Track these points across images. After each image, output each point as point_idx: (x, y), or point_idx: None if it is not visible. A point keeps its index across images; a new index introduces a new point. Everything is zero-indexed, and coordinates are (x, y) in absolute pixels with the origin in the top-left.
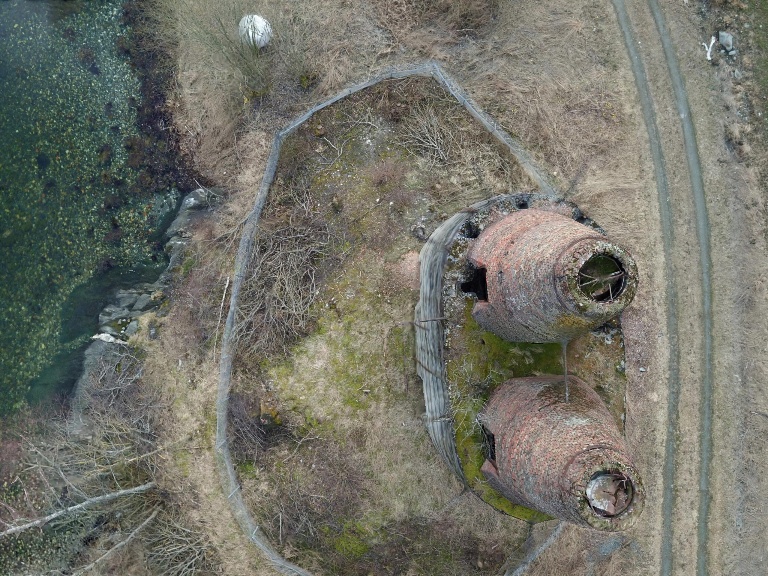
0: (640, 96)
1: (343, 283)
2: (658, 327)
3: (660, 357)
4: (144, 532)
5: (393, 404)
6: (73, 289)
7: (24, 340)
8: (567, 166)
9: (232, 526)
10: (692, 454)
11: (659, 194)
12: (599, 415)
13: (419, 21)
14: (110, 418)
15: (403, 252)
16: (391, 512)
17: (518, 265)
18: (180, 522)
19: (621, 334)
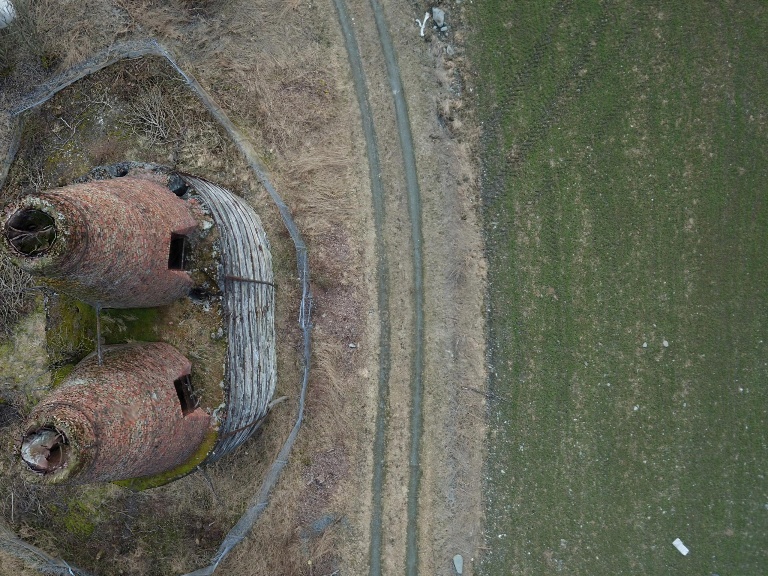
0: (353, 73)
1: None
2: (369, 303)
3: (371, 333)
4: None
5: None
6: None
7: None
8: (283, 143)
9: None
10: (402, 430)
11: (371, 170)
12: (122, 376)
13: (154, 0)
14: None
15: None
16: (107, 490)
17: None
18: None
19: (219, 301)
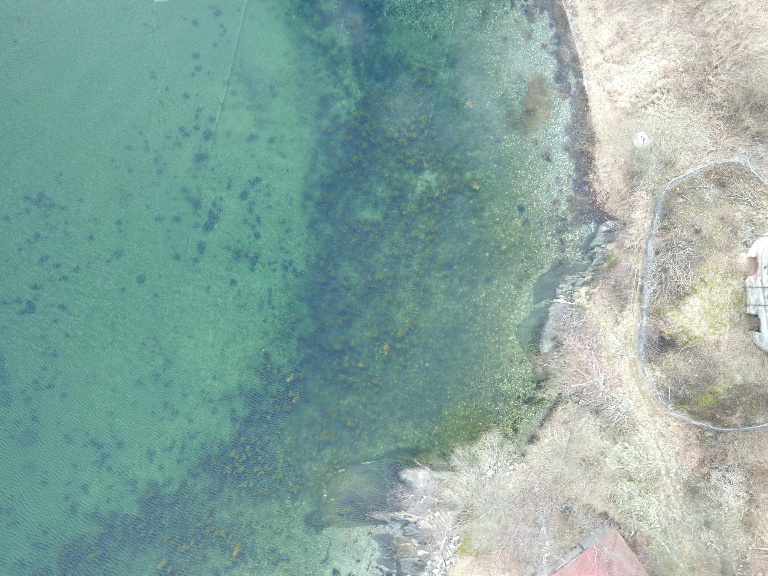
0: None
1: (707, 269)
2: None
3: None
4: None
5: (733, 328)
6: (539, 276)
7: (513, 304)
8: None
9: (640, 395)
10: None
11: None
12: None
13: (731, 134)
14: None
15: (738, 253)
16: (735, 381)
17: None
18: (614, 393)
19: None
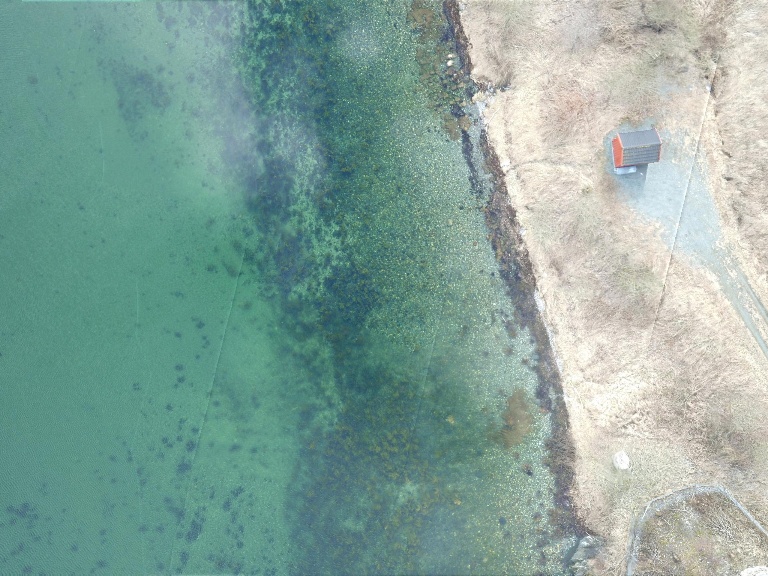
0: None
1: None
2: None
3: None
4: None
5: None
6: None
7: None
8: None
9: None
10: None
11: None
12: None
13: (710, 458)
14: None
15: None
16: None
17: None
18: None
19: None
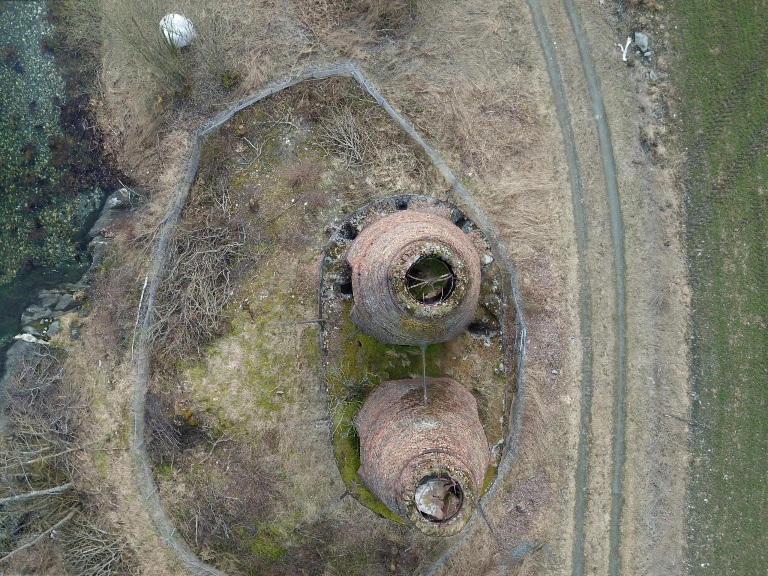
0: (555, 97)
1: (257, 284)
2: (571, 329)
3: (573, 359)
4: (60, 534)
5: (306, 406)
6: None
7: None
8: (482, 167)
9: (150, 528)
10: (605, 457)
11: (573, 195)
12: (455, 418)
13: (340, 21)
14: (30, 419)
15: (316, 253)
16: (303, 514)
17: (368, 267)
18: (97, 524)
19: (500, 336)
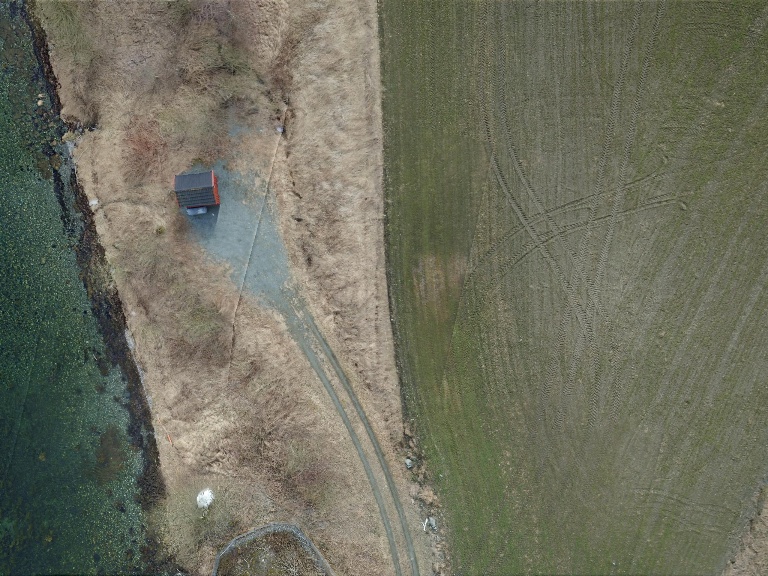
0: (391, 550)
1: None
2: None
3: None
4: None
5: None
6: None
7: None
8: None
9: None
10: None
11: None
12: None
13: (288, 496)
14: None
15: None
16: None
17: None
18: None
19: None
